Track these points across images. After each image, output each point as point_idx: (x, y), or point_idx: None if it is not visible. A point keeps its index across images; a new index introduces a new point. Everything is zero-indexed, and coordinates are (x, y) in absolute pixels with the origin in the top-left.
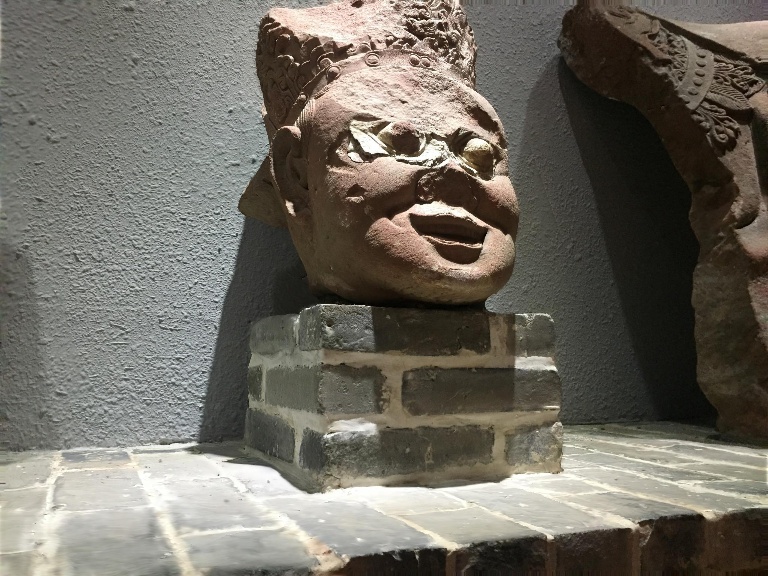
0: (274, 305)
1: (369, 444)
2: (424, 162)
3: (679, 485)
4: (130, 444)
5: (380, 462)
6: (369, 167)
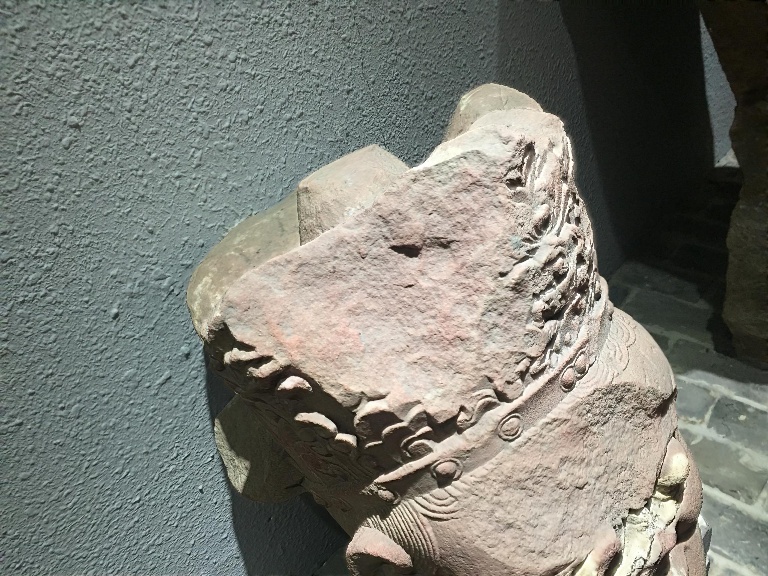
0: None
1: None
2: (632, 566)
3: None
4: None
5: None
6: None
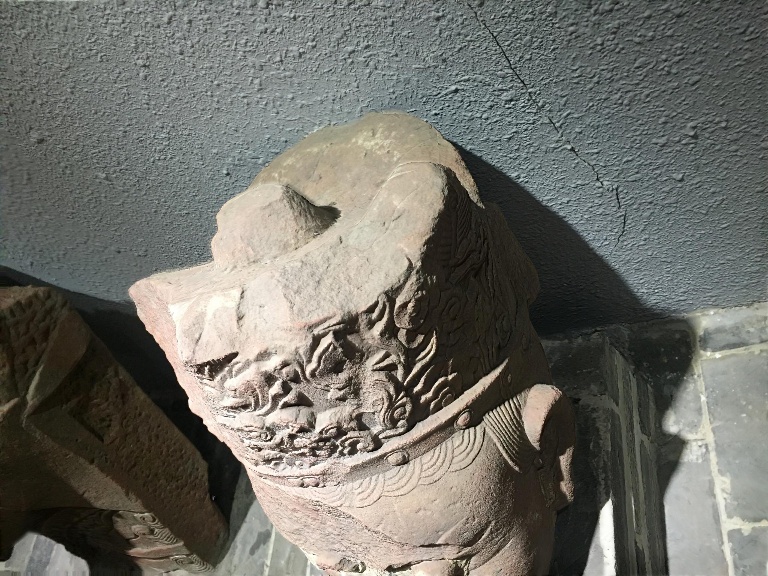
0: None
1: None
2: None
3: None
4: None
5: None
6: None
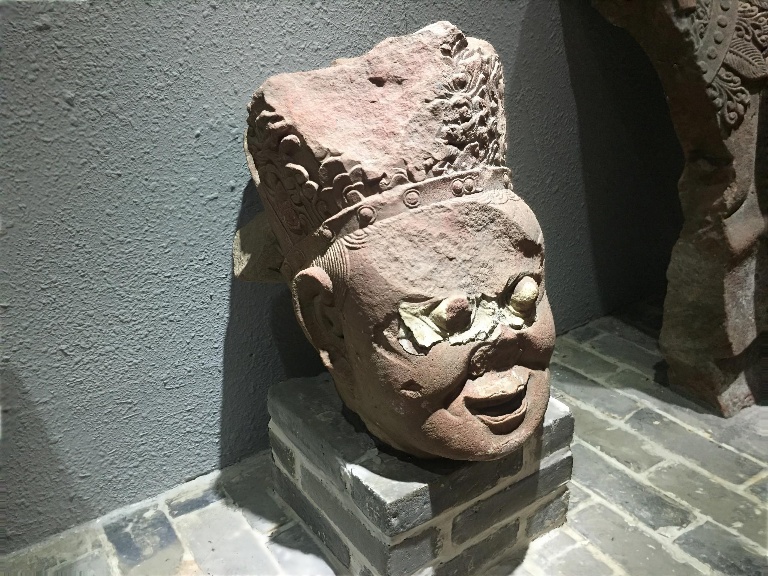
0: (273, 332)
1: None
2: (476, 336)
3: (661, 542)
4: (159, 492)
5: None
6: (425, 361)
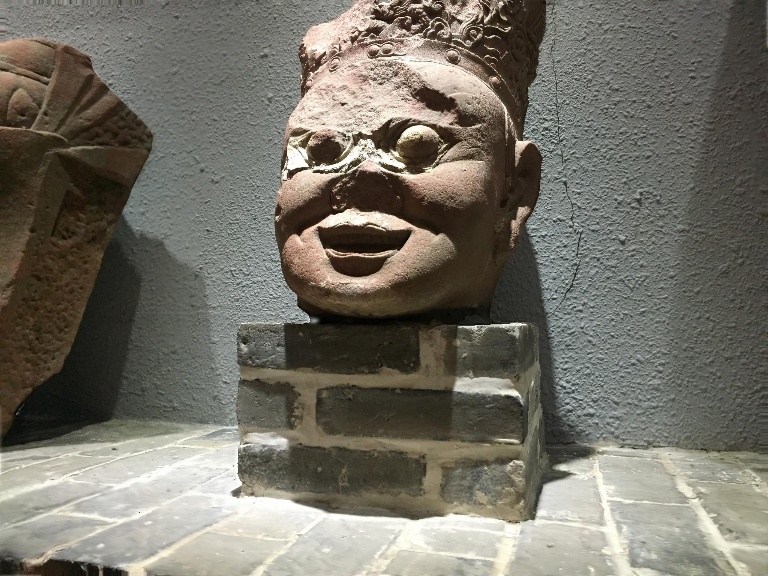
0: None
1: (279, 458)
2: (341, 168)
3: (617, 574)
4: None
5: (290, 477)
6: (288, 184)
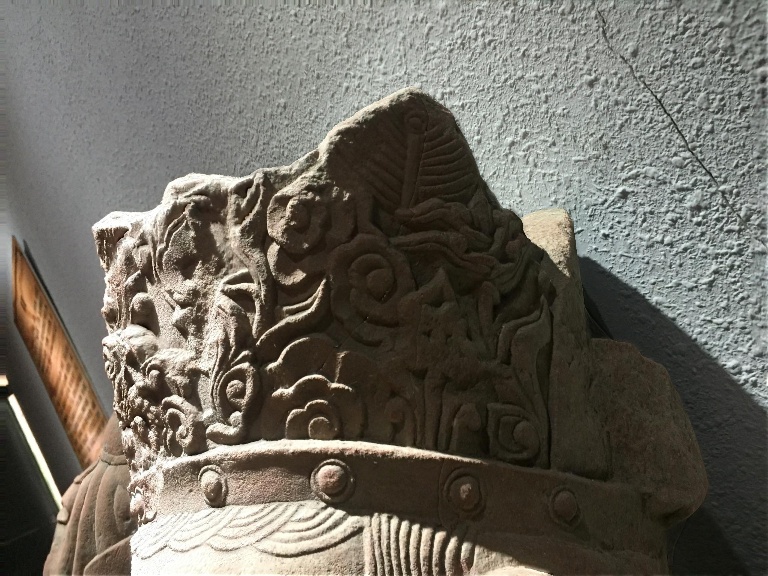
0: None
1: None
2: None
3: None
4: None
5: None
6: None
